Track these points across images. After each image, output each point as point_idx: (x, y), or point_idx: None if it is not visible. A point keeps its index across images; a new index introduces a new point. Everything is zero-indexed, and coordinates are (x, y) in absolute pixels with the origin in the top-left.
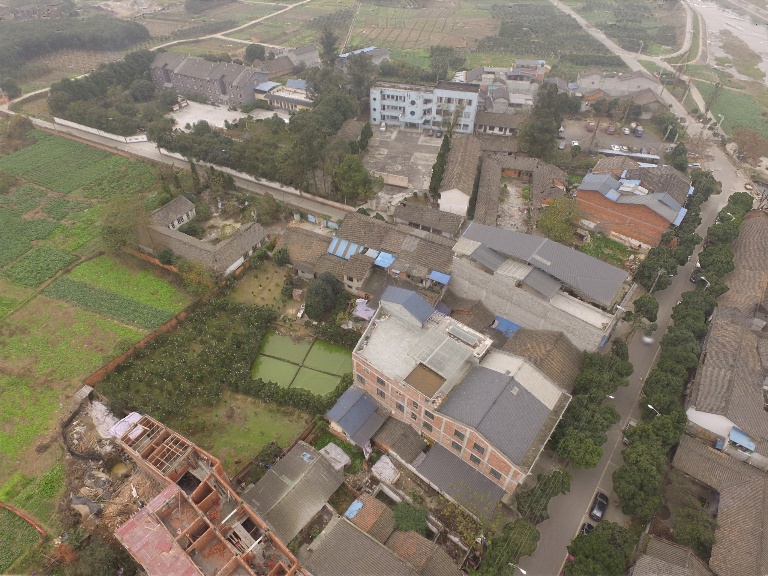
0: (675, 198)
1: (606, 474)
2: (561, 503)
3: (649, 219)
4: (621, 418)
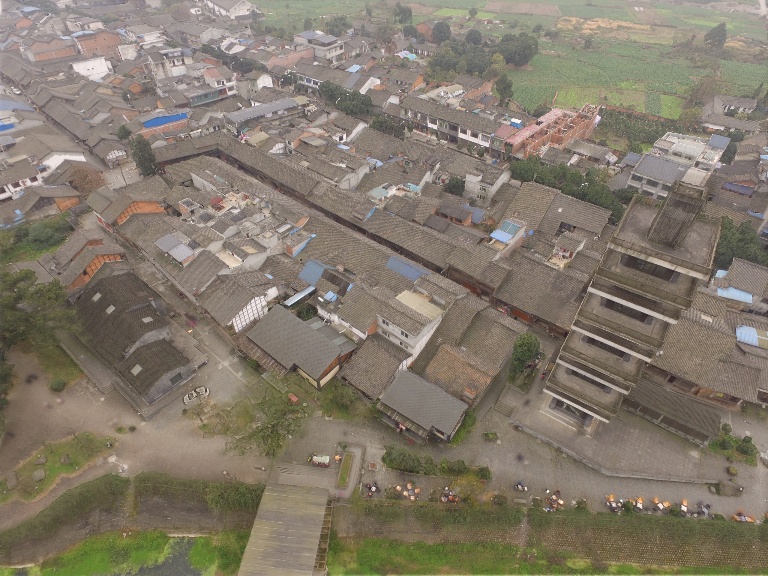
0: None
1: None
2: None
3: None
4: None
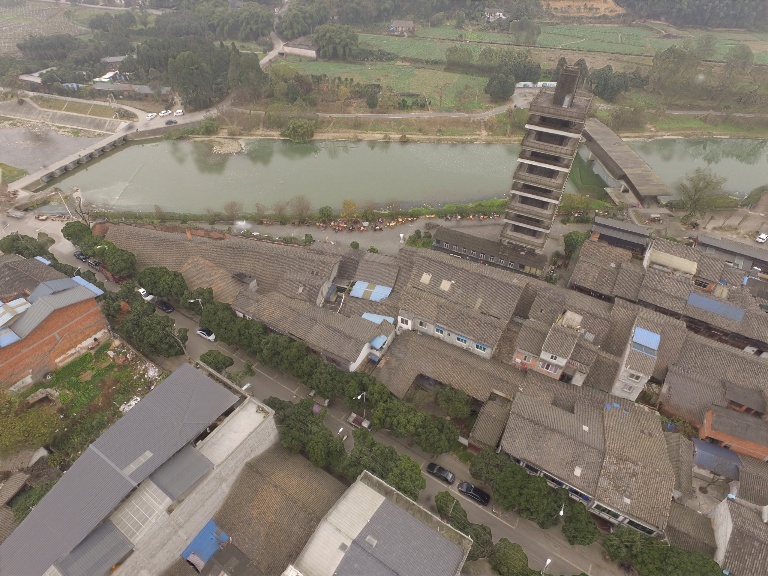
0: (54, 278)
1: None
2: None
3: (73, 315)
4: None
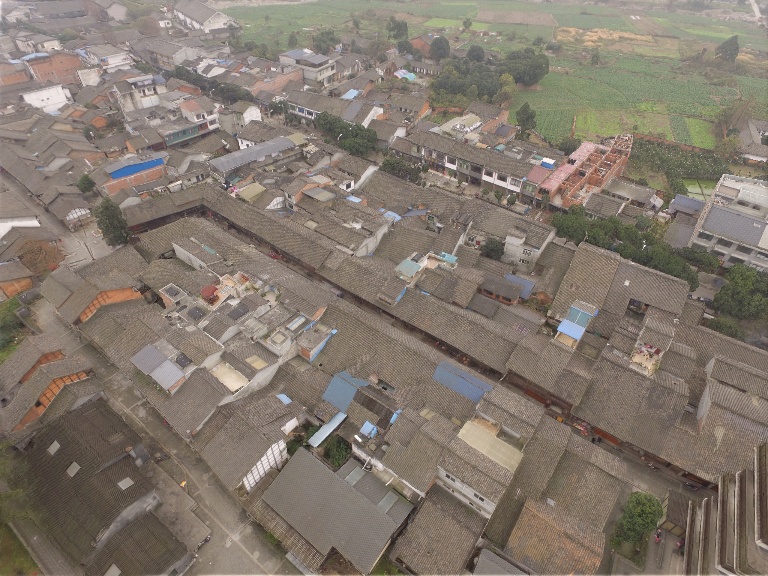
0: None
1: None
2: (697, 289)
3: None
4: None
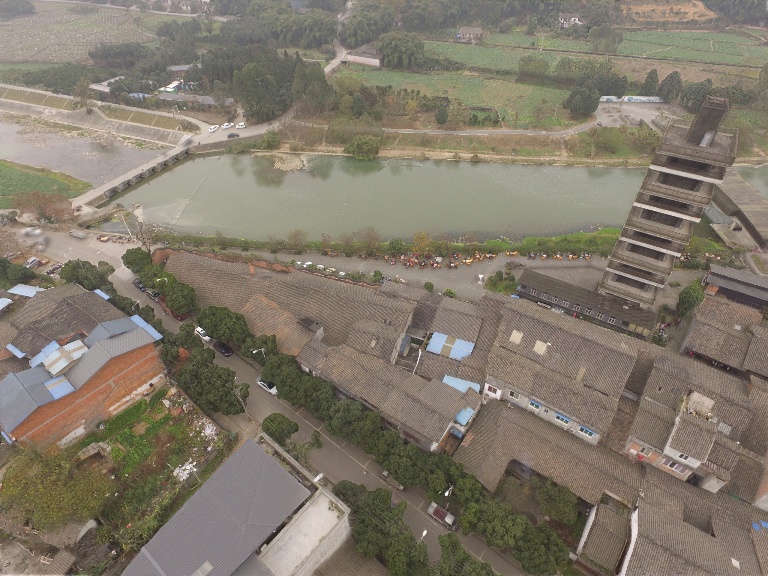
0: (112, 318)
1: (497, 569)
2: None
3: (130, 361)
4: (421, 520)
